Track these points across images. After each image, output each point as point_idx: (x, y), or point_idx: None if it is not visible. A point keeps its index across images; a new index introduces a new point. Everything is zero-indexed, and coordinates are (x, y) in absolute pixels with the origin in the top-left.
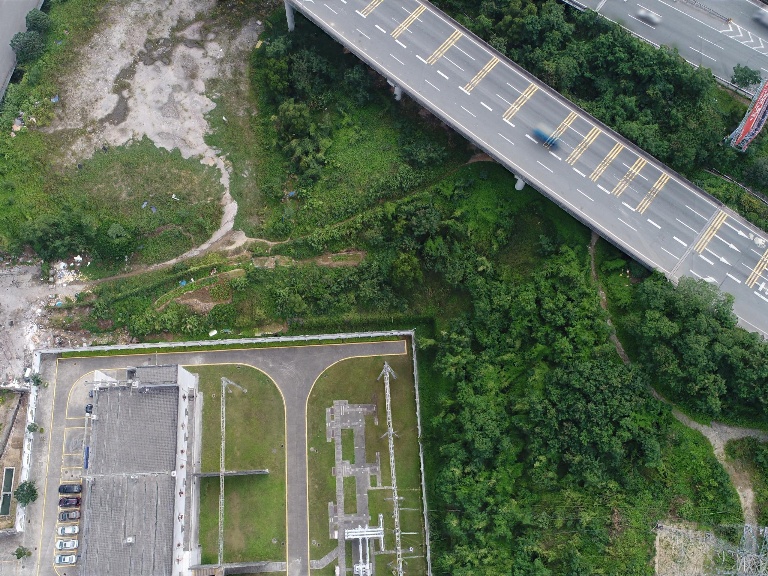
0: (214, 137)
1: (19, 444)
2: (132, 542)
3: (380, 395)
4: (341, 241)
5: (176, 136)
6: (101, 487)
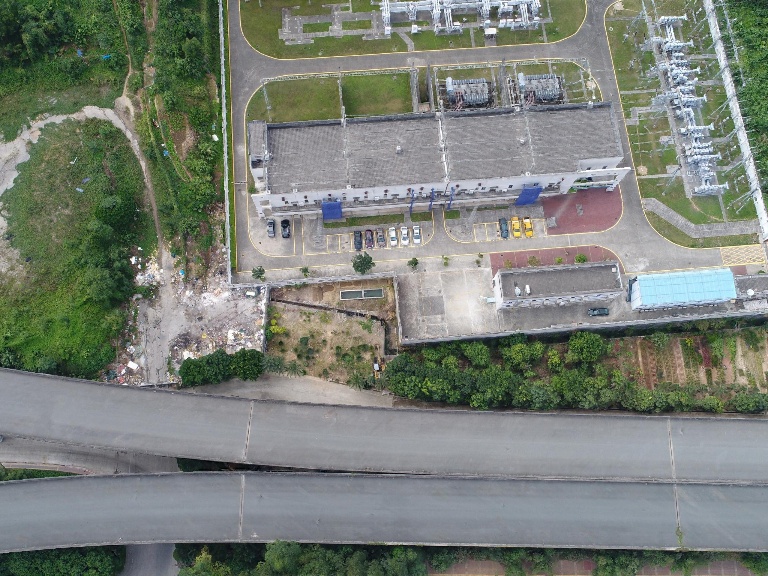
0: (7, 133)
1: (319, 294)
2: (401, 149)
3: (275, 5)
4: (133, 7)
5: (2, 170)
6: (357, 159)
